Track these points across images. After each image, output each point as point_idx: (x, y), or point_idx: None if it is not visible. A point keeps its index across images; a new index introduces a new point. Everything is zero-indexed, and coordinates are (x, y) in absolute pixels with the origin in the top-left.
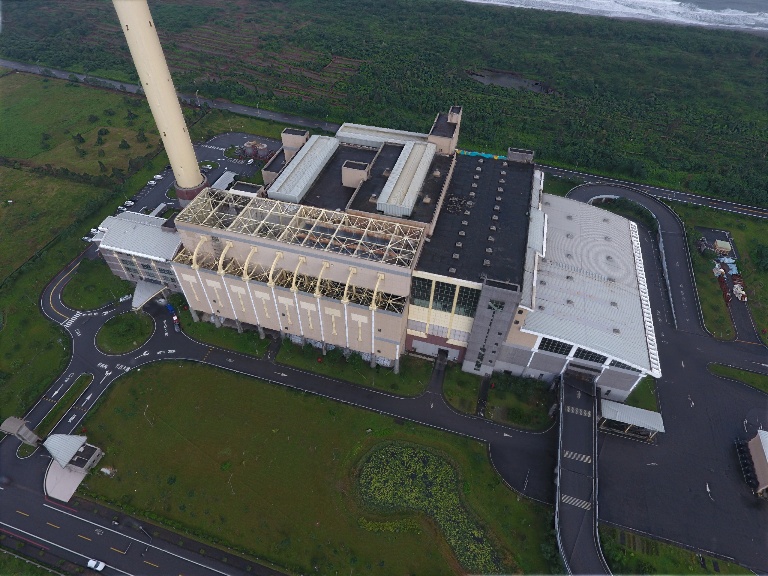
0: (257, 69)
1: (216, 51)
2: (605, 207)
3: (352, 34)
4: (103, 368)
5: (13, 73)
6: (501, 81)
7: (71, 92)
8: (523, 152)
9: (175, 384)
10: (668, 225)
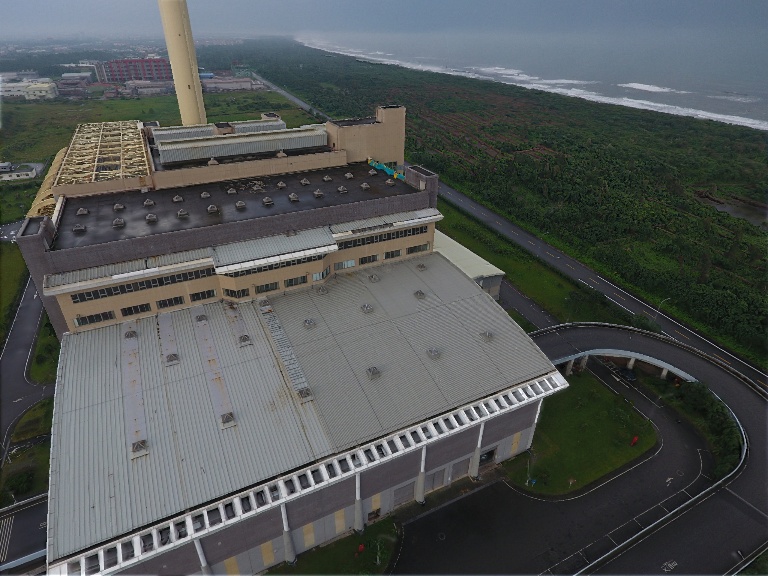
0: (452, 139)
1: (443, 125)
2: (655, 386)
3: (591, 137)
4: (10, 233)
5: (297, 109)
6: (744, 213)
7: (304, 121)
8: (424, 173)
9: (2, 260)
10: (763, 488)
